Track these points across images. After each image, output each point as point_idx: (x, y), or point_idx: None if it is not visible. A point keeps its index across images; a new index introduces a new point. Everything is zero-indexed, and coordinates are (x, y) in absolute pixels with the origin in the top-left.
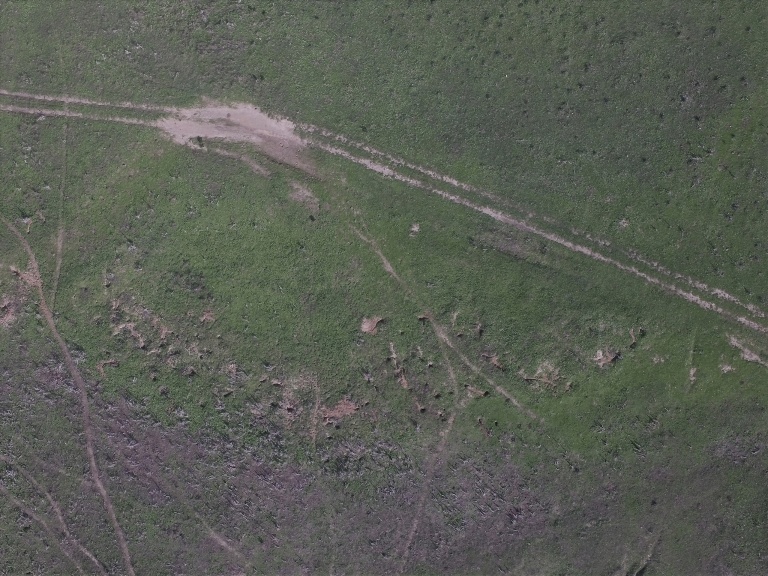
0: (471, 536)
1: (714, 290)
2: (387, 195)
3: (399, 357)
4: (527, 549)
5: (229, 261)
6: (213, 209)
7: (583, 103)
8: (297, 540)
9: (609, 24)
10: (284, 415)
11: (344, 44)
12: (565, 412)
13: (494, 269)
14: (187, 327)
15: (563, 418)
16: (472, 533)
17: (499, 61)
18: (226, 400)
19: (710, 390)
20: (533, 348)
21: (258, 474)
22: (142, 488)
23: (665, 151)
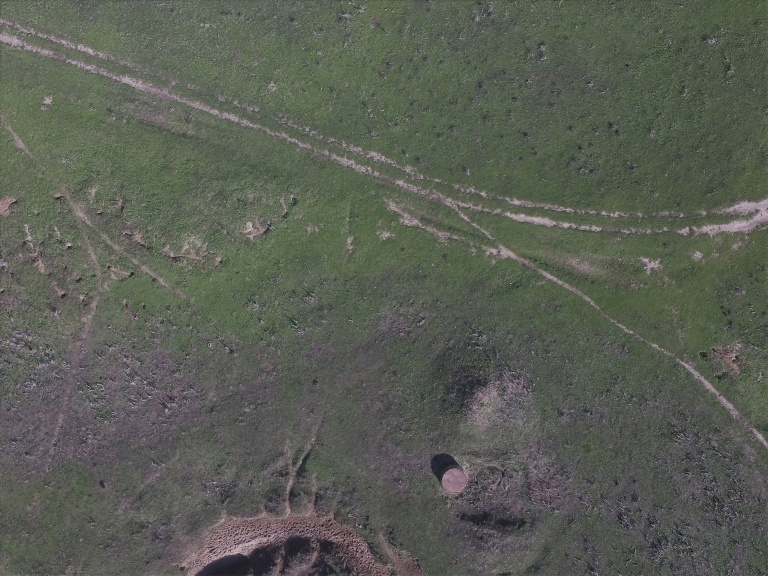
0: (121, 429)
1: (369, 153)
2: (16, 67)
3: (34, 239)
4: (182, 439)
5: None
6: None
7: None
8: None
9: None
10: None
11: None
12: (216, 290)
13: (134, 141)
14: None
15: (215, 296)
16: (123, 425)
17: None
18: None
19: (369, 259)
20: (178, 223)
21: None
22: None
23: (315, 10)
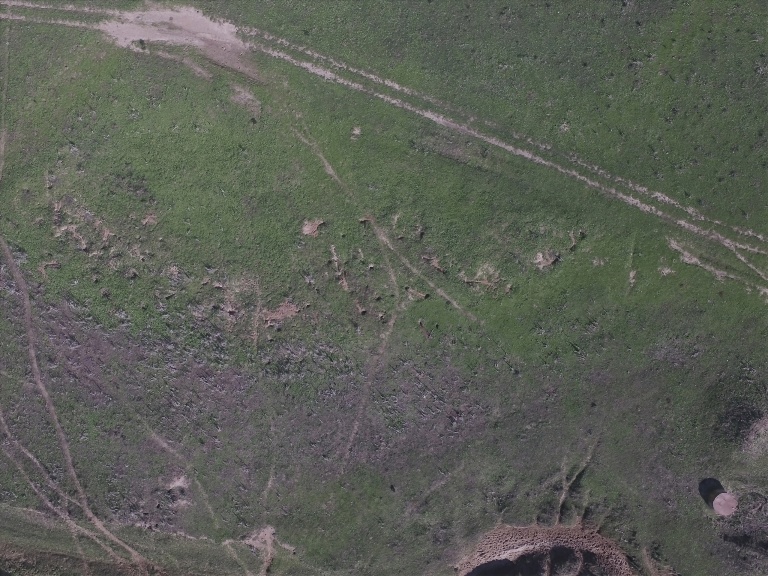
0: (411, 438)
1: (654, 193)
2: (329, 98)
3: (340, 259)
4: (467, 451)
5: (171, 164)
6: (155, 111)
7: (525, 8)
8: (238, 442)
9: None
10: (225, 317)
11: None
12: (505, 314)
13: (435, 172)
14: (129, 229)
15: (503, 320)
16: (413, 435)
17: None
18: (168, 302)
19: (650, 293)
20: (473, 250)
21: (199, 376)
22: (83, 389)
23: (606, 56)
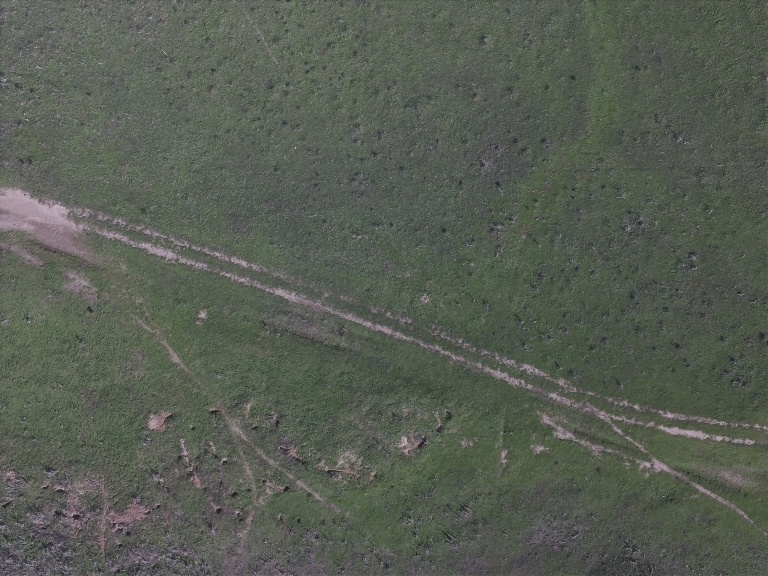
0: None
1: (522, 366)
2: (171, 281)
3: (190, 454)
4: None
5: (3, 360)
6: None
7: (378, 173)
8: None
9: (402, 88)
10: (69, 523)
11: (119, 121)
12: (371, 504)
13: (289, 355)
14: None
15: (369, 511)
16: None
17: (287, 132)
18: (4, 511)
19: (523, 472)
20: (333, 438)
21: None
22: None
23: (466, 220)
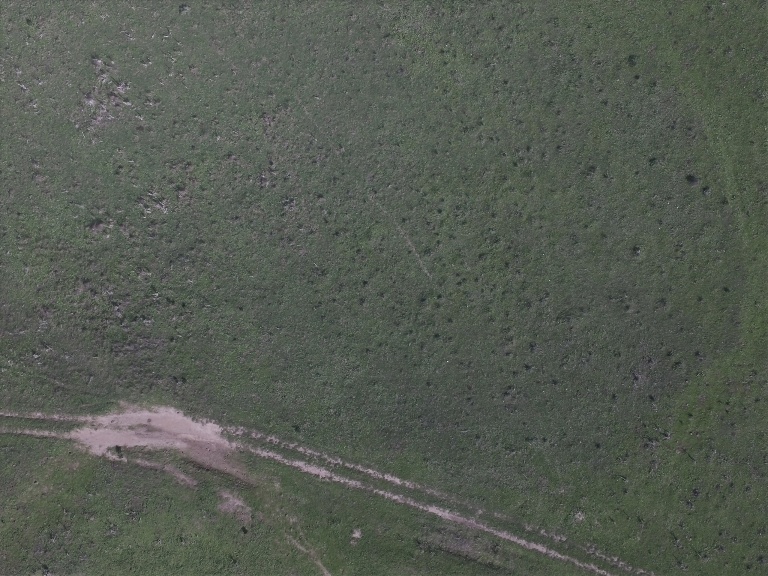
0: None
1: None
2: (325, 499)
3: None
4: None
5: None
6: (136, 526)
7: (530, 386)
8: None
9: (554, 300)
10: None
11: (272, 336)
12: None
13: (443, 574)
14: None
15: None
16: None
17: (439, 345)
18: None
19: None
20: None
21: None
22: None
23: (620, 435)
